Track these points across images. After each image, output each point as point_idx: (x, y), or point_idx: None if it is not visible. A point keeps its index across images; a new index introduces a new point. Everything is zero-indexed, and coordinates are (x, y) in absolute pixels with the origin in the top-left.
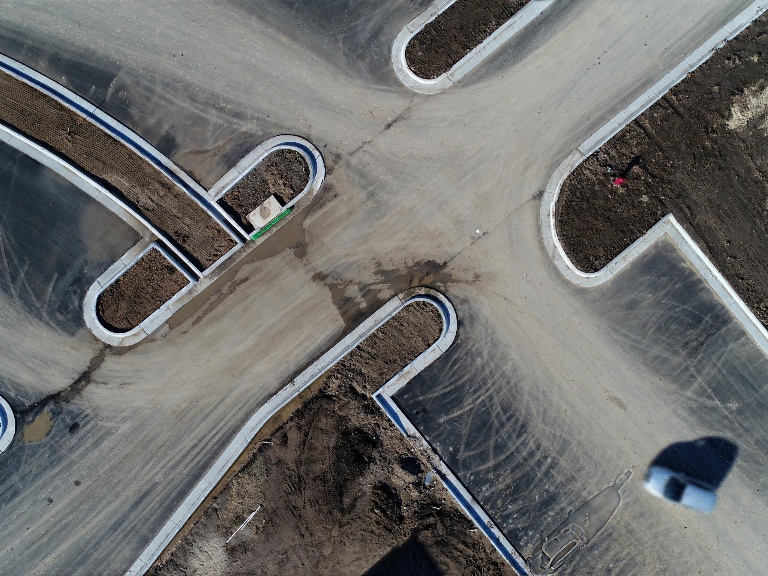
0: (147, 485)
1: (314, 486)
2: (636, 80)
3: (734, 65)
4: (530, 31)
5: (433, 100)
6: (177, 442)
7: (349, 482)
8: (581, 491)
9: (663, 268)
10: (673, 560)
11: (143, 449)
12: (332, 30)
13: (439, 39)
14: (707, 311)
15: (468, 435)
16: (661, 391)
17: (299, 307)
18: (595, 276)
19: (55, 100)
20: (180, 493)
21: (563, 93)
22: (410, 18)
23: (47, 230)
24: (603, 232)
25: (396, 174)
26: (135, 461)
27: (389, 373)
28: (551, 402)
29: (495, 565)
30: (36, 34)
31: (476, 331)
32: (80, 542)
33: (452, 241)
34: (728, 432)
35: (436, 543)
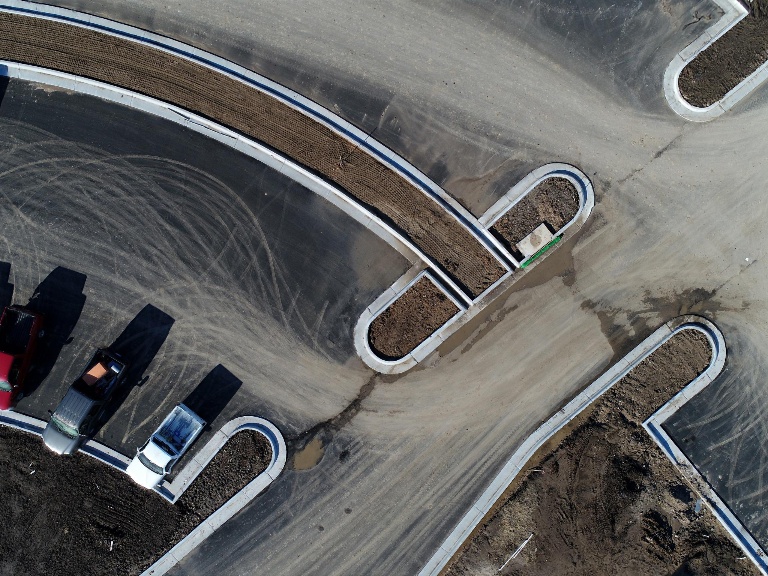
0: (417, 513)
1: (586, 514)
2: None
3: None
4: None
5: (704, 128)
6: (447, 470)
7: (620, 510)
8: None
9: None
10: None
11: (413, 477)
12: (604, 58)
13: (712, 67)
14: None
15: (737, 463)
16: None
17: (568, 335)
18: None
19: (327, 128)
20: (450, 521)
21: None
22: (682, 46)
23: (318, 258)
24: None
25: (666, 202)
26: (405, 489)
27: (659, 401)
28: None
29: None
30: (309, 62)
31: (744, 359)
32: (351, 570)
33: (721, 269)
34: None
35: (707, 571)
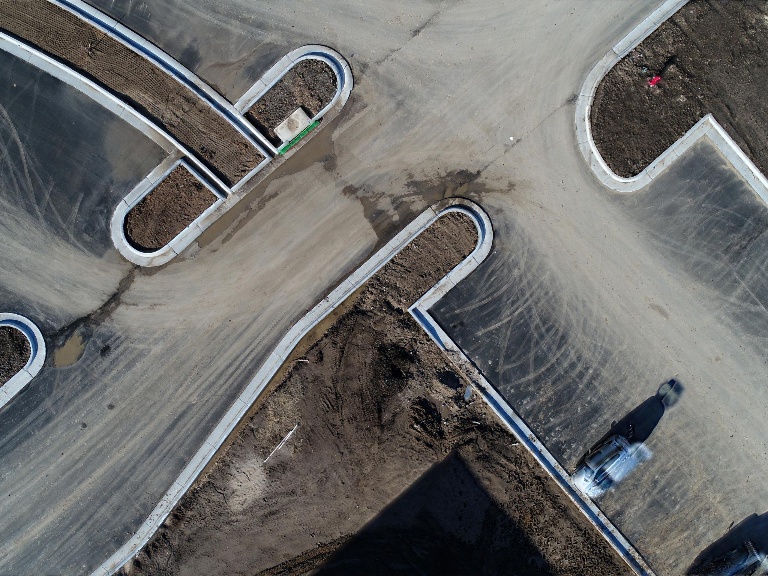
0: (181, 407)
1: (351, 403)
2: None
3: None
4: None
5: (462, 4)
6: (210, 363)
7: (387, 398)
8: (624, 402)
9: (703, 171)
10: (720, 469)
11: (176, 371)
12: None
13: None
14: (749, 213)
15: (507, 348)
16: (704, 297)
17: (331, 222)
18: (633, 181)
19: (75, 16)
20: (215, 414)
21: None
22: None
23: (71, 150)
24: (641, 135)
25: (426, 82)
26: (168, 383)
27: (425, 286)
28: (591, 312)
29: (538, 479)
30: None
31: (512, 241)
32: (115, 467)
33: (485, 149)
34: None
35: (477, 458)
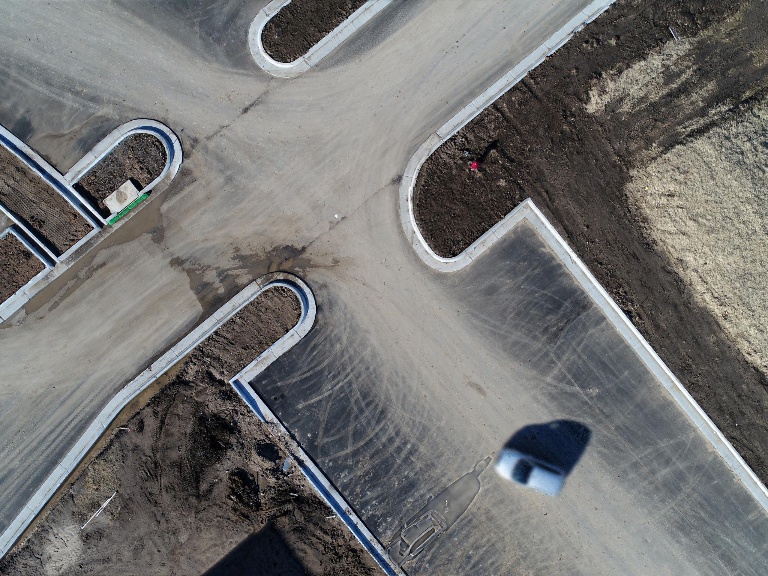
0: (3, 471)
1: (170, 472)
2: (495, 64)
3: (592, 48)
4: (388, 14)
5: (290, 84)
6: (33, 428)
7: (206, 468)
8: (441, 477)
9: (522, 253)
10: (533, 547)
11: None
12: (188, 13)
13: (295, 22)
14: (567, 296)
15: (327, 421)
16: (521, 377)
17: (157, 292)
18: (454, 261)
19: None
20: (36, 479)
21: (421, 77)
22: (267, 1)
23: None
24: (461, 217)
25: (254, 158)
26: None
27: (247, 359)
28: (410, 388)
29: (354, 552)
30: None
31: (335, 316)
32: None
33: (310, 226)
34: (588, 418)
35: (294, 530)
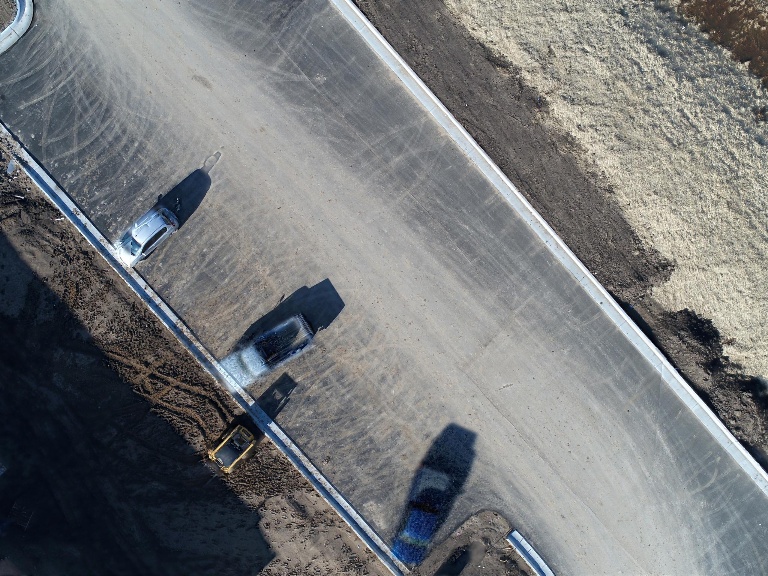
0: None
1: None
2: None
3: None
4: None
5: None
6: None
7: None
8: (170, 175)
9: None
10: (268, 242)
11: None
12: None
13: None
14: None
15: (50, 121)
16: (246, 67)
17: None
18: None
19: None
20: None
21: None
22: None
23: None
24: None
25: None
26: None
27: None
28: (135, 84)
29: (85, 254)
30: None
31: (53, 14)
32: None
33: None
34: (317, 107)
35: (20, 232)
